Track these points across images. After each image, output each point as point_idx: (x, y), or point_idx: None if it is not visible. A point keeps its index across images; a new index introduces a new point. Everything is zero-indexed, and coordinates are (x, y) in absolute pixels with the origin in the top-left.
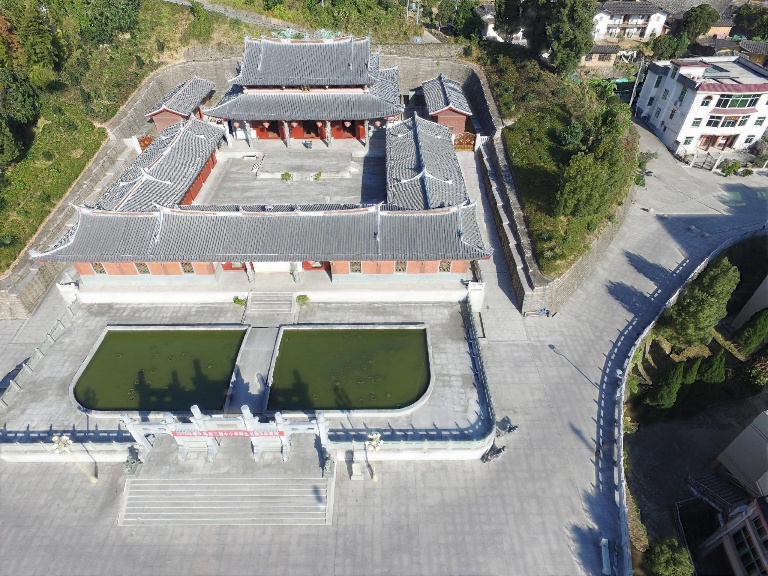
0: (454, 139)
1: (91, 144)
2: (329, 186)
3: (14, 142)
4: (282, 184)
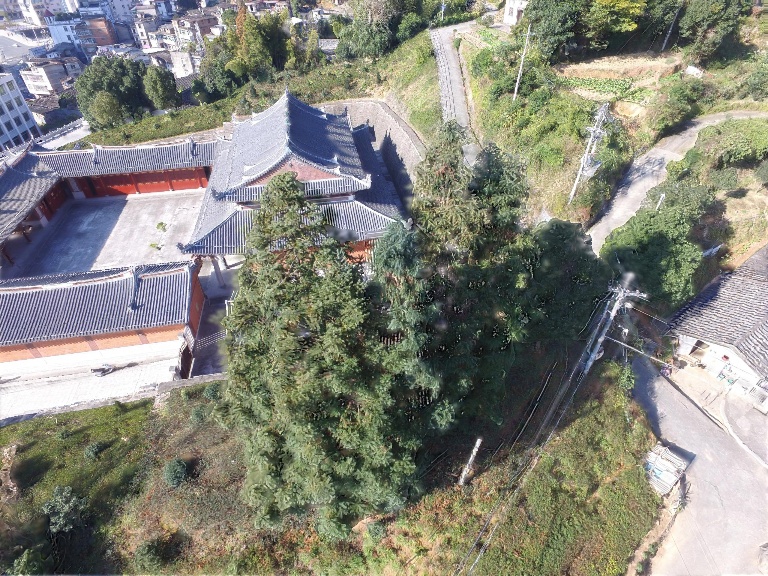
0: (186, 343)
1: (204, 124)
2: (141, 260)
3: (163, 98)
4: (158, 230)
